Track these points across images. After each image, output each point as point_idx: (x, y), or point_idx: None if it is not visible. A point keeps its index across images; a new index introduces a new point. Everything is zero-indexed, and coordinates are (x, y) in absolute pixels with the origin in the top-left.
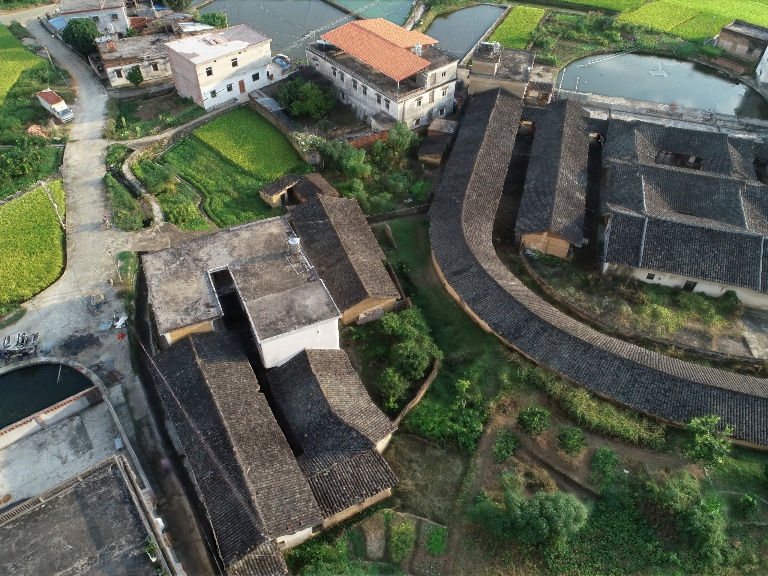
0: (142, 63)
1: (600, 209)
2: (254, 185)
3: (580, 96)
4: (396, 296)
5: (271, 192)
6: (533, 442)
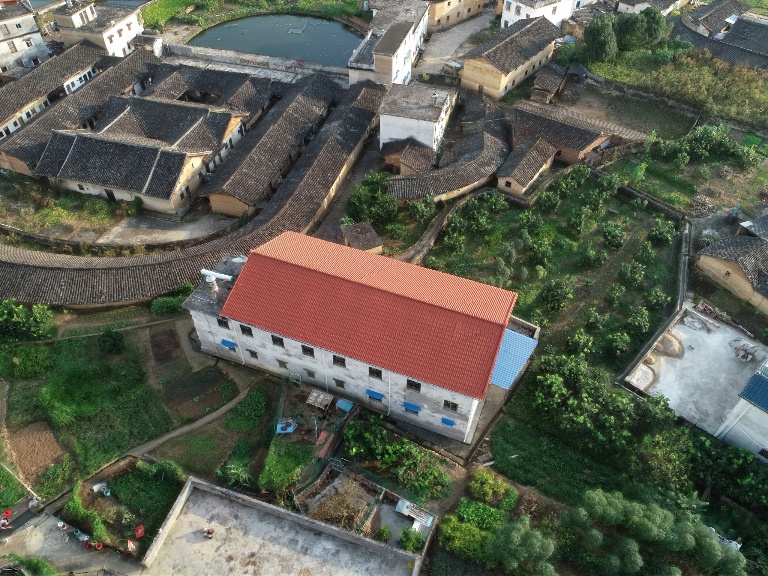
0: None
1: None
2: None
3: (185, 49)
4: None
5: None
6: None
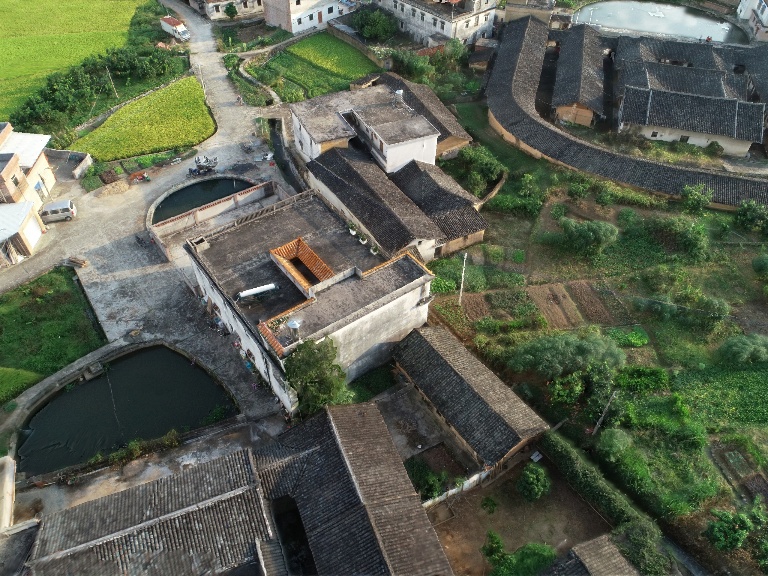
0: (236, 0)
1: (614, 99)
2: (344, 82)
3: (593, 27)
4: (470, 138)
5: (361, 83)
6: (578, 208)
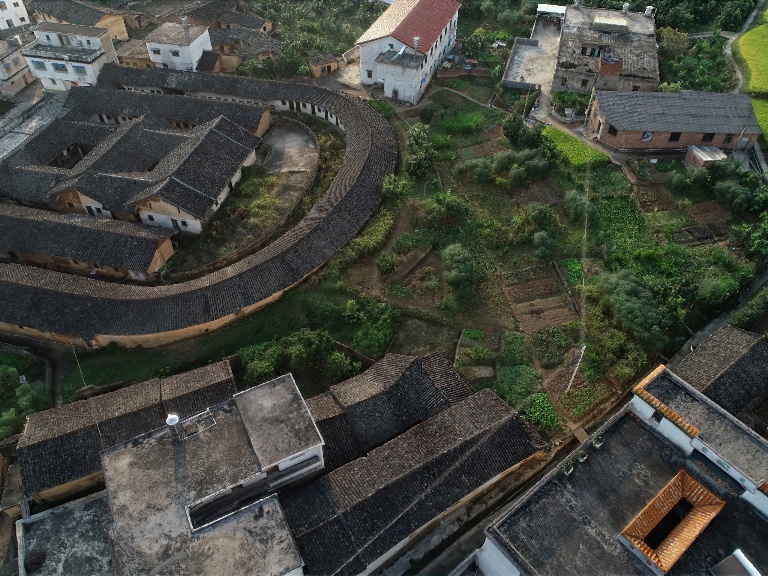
0: None
1: None
2: None
3: None
4: (227, 362)
5: None
6: (396, 274)
